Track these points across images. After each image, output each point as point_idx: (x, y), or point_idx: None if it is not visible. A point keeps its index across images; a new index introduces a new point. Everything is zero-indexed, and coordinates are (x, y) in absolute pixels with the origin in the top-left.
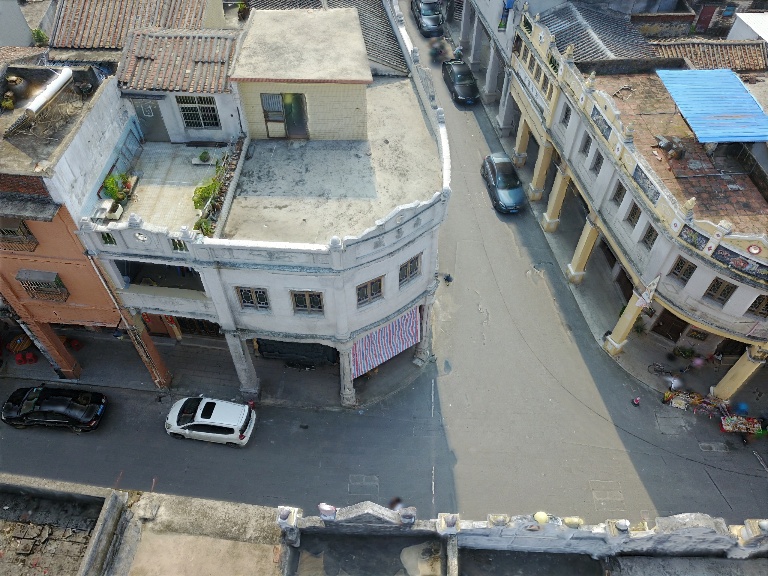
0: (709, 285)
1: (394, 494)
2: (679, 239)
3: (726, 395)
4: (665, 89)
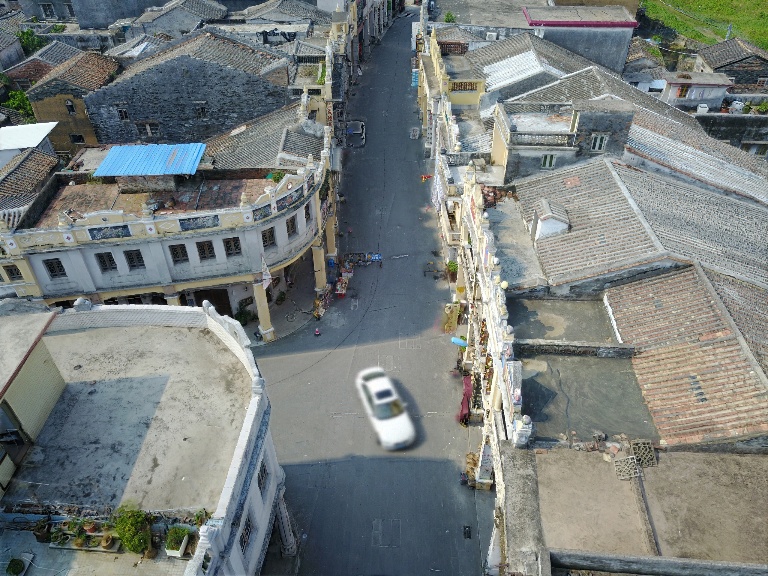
0: (286, 230)
1: (391, 506)
2: (257, 222)
3: (325, 281)
4: (82, 195)
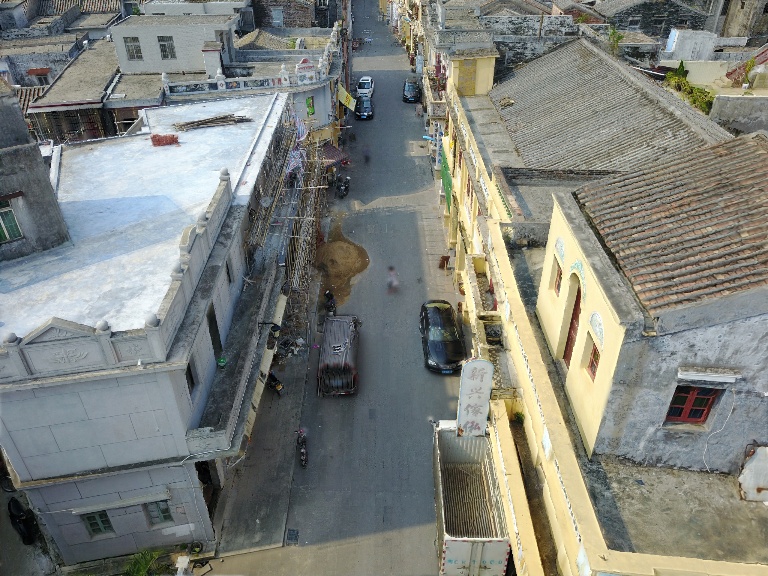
0: None
1: None
2: None
3: None
4: None
